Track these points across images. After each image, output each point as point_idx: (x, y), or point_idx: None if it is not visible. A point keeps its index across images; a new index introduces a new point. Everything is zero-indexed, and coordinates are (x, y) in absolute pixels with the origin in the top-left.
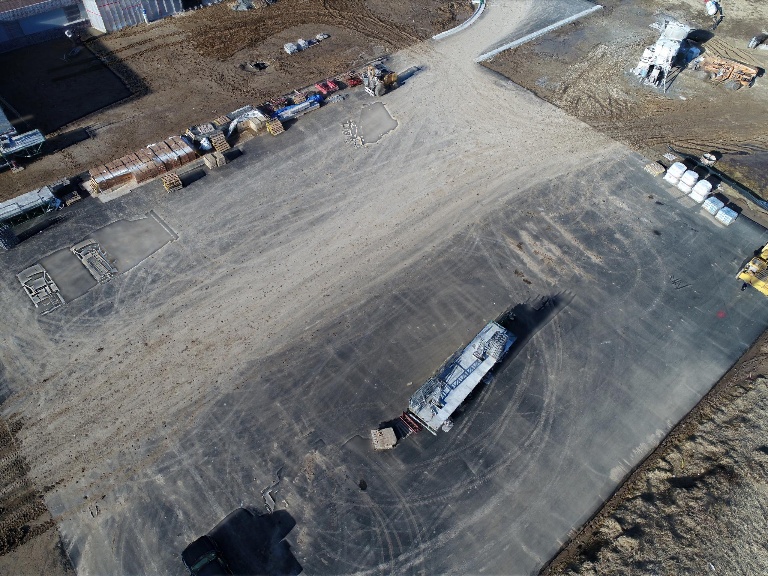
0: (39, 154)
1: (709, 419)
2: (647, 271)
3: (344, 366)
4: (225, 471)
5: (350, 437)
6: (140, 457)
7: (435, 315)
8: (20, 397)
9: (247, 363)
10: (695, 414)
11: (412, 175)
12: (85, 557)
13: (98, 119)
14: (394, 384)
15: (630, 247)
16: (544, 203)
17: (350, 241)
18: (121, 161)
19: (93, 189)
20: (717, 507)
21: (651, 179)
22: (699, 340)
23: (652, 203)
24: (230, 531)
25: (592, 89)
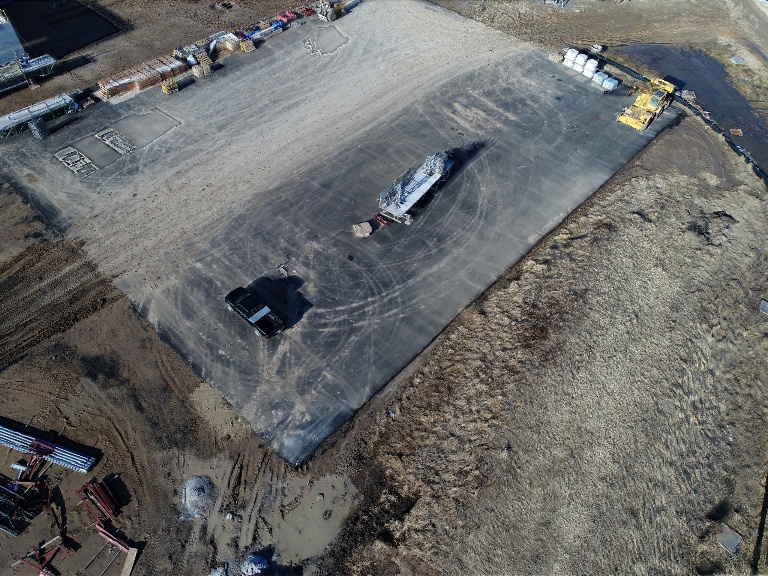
0: (50, 75)
1: (597, 204)
2: (551, 122)
3: (327, 192)
4: (247, 257)
5: (337, 232)
6: (181, 254)
7: (393, 158)
8: (78, 227)
9: (252, 195)
10: (588, 203)
11: (365, 72)
12: (152, 311)
13: (95, 49)
14: (366, 200)
15: (538, 108)
16: (471, 84)
17: (321, 117)
18: (124, 74)
19: (103, 95)
20: (600, 242)
21: (553, 65)
22: (590, 161)
23: (554, 80)
24: (257, 289)
25: (505, 8)
